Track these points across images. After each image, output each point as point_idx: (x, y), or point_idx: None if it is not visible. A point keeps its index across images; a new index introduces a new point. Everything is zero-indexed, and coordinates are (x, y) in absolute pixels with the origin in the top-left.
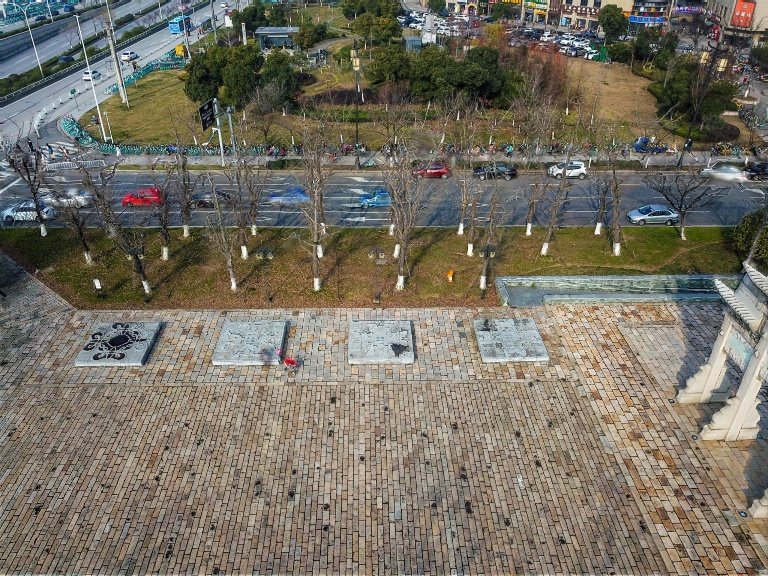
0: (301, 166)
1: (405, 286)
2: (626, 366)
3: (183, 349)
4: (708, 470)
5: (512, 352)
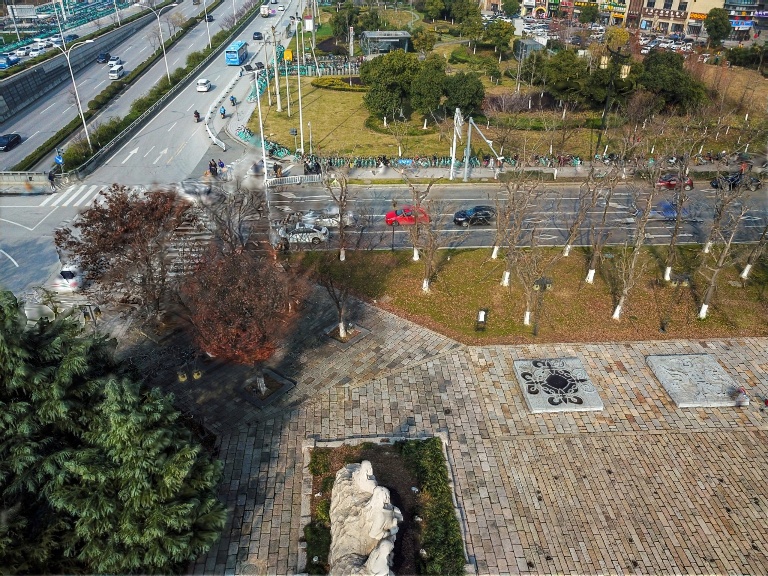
0: (532, 178)
1: None
2: None
3: (626, 389)
4: None
5: None
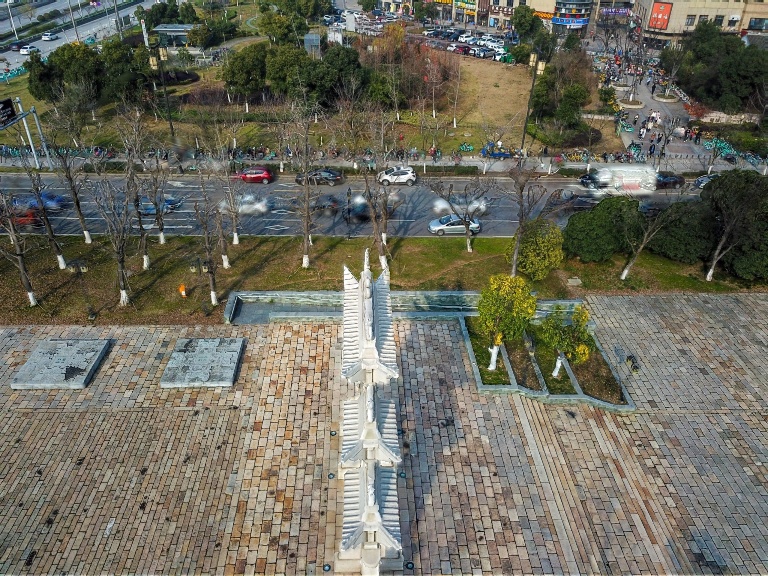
0: (120, 169)
1: (132, 301)
2: (311, 393)
3: None
4: (321, 515)
5: (194, 376)
